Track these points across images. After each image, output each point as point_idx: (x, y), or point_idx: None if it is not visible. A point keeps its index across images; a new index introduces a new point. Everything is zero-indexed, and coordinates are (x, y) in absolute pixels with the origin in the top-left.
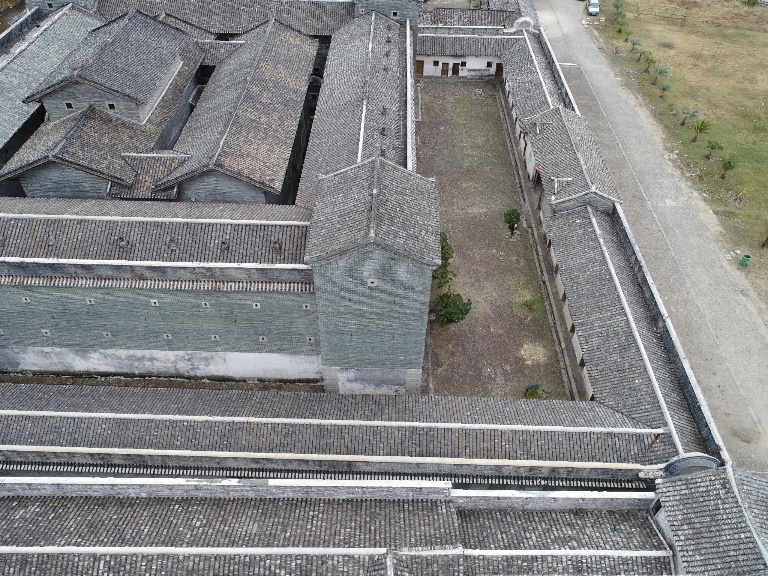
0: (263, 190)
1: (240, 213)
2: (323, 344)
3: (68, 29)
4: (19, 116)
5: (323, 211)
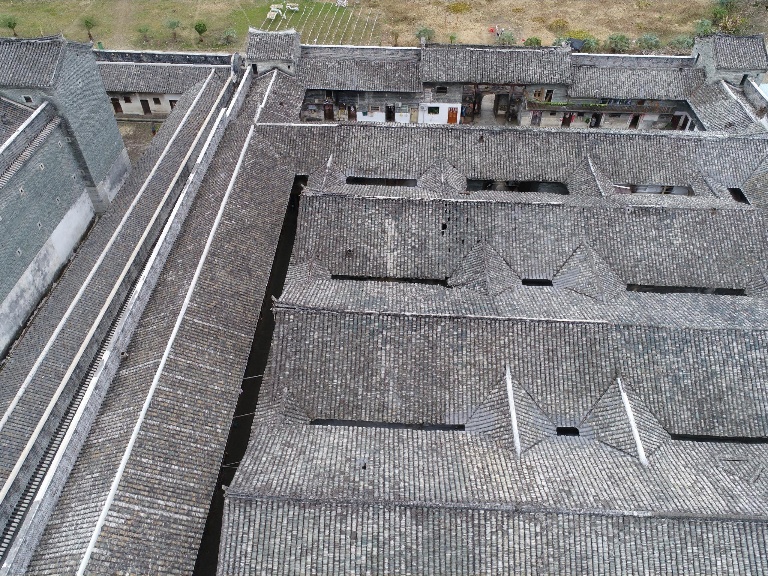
0: None
1: None
2: (88, 164)
3: None
4: None
5: (2, 75)
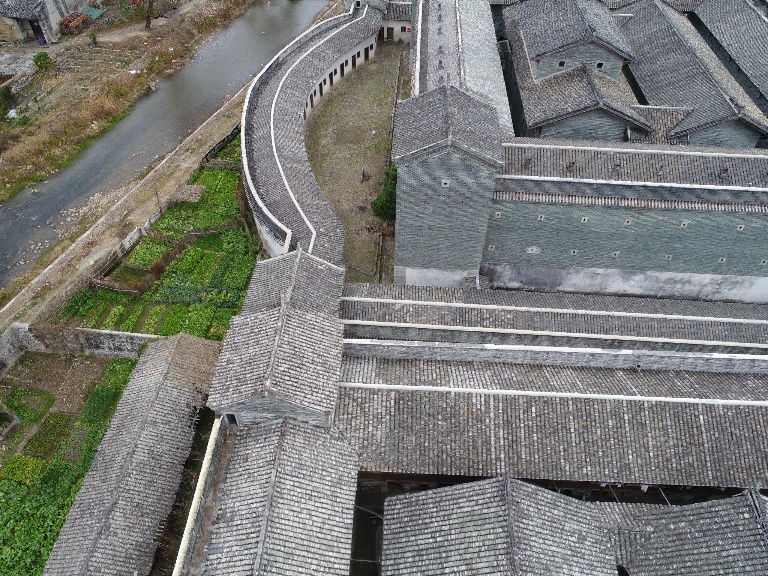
0: (758, 140)
1: None
2: None
3: (469, 1)
4: (497, 74)
5: None
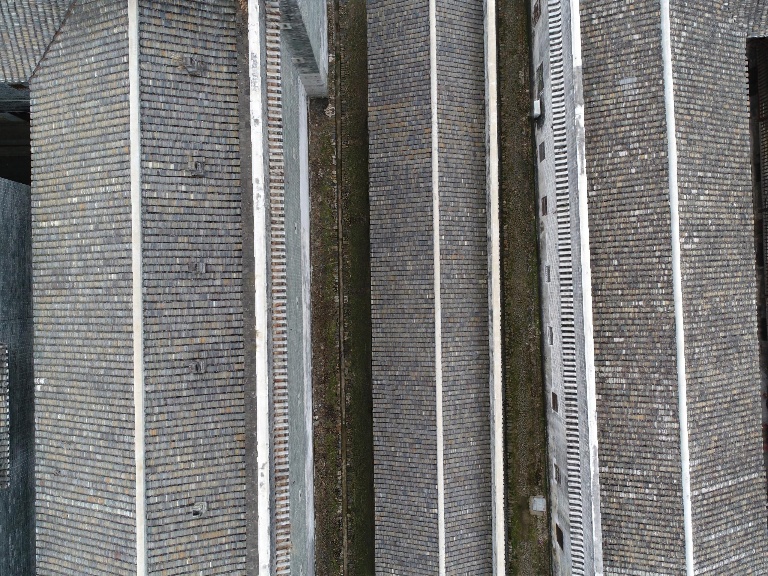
0: None
1: (85, 168)
2: (313, 47)
3: None
4: None
5: None
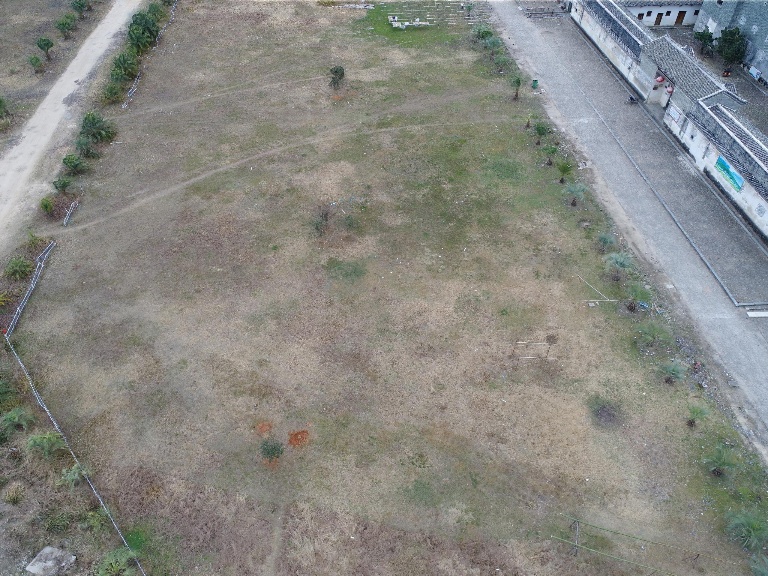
0: None
1: None
2: None
3: None
4: None
5: None
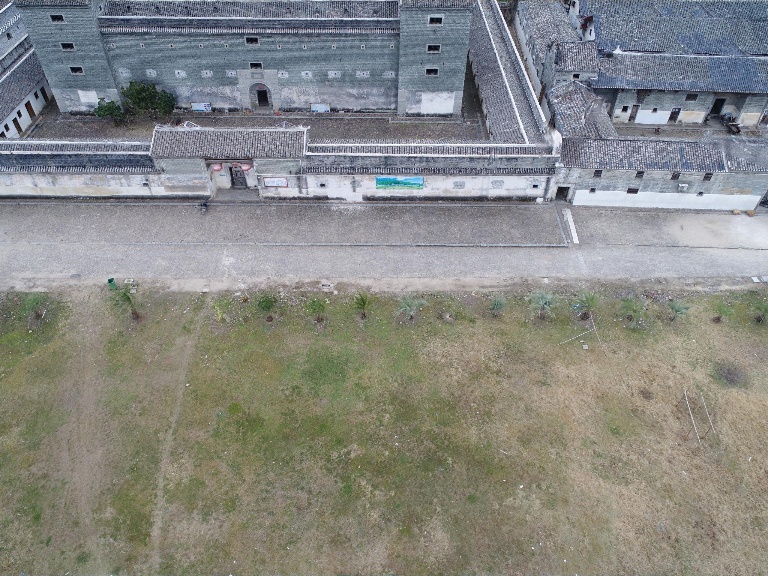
0: None
1: None
2: None
3: None
4: None
5: None
